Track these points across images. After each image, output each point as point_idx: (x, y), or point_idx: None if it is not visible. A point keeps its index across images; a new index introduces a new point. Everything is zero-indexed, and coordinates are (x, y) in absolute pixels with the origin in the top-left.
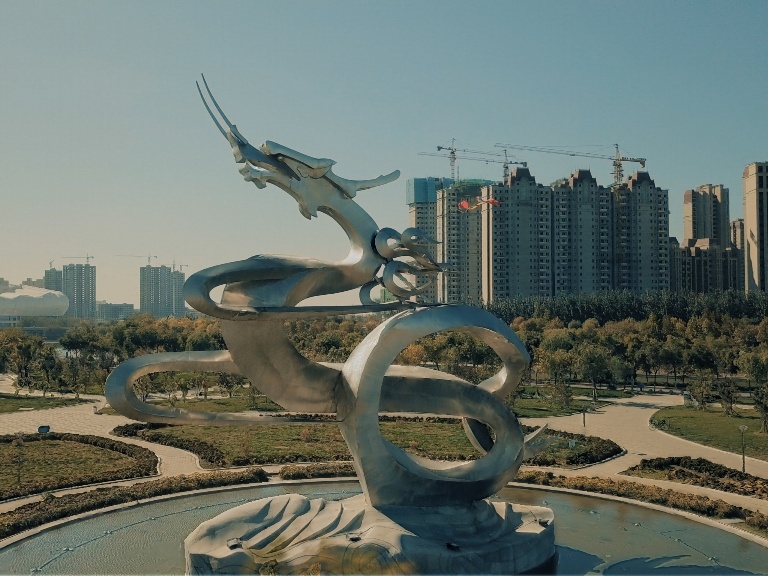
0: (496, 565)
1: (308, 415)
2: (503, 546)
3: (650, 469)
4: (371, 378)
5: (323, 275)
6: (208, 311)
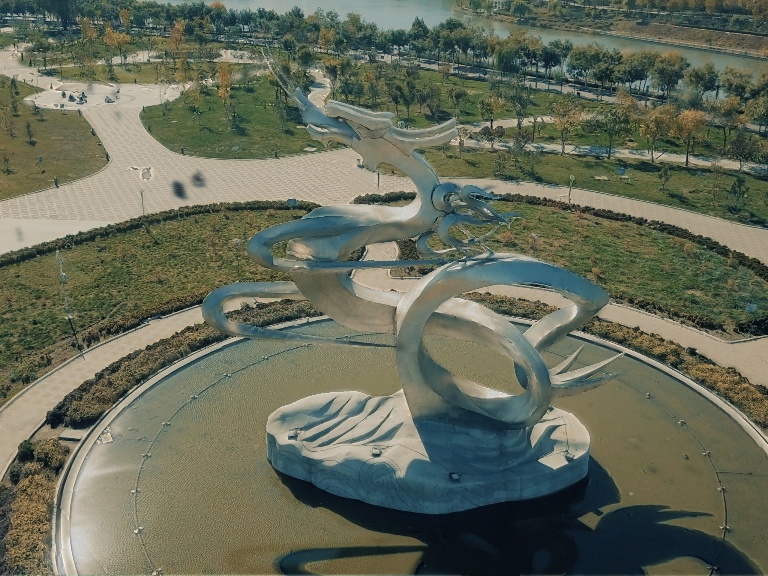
0: (500, 492)
1: (537, 197)
2: (510, 478)
3: None
4: (412, 324)
5: (377, 229)
6: (267, 266)
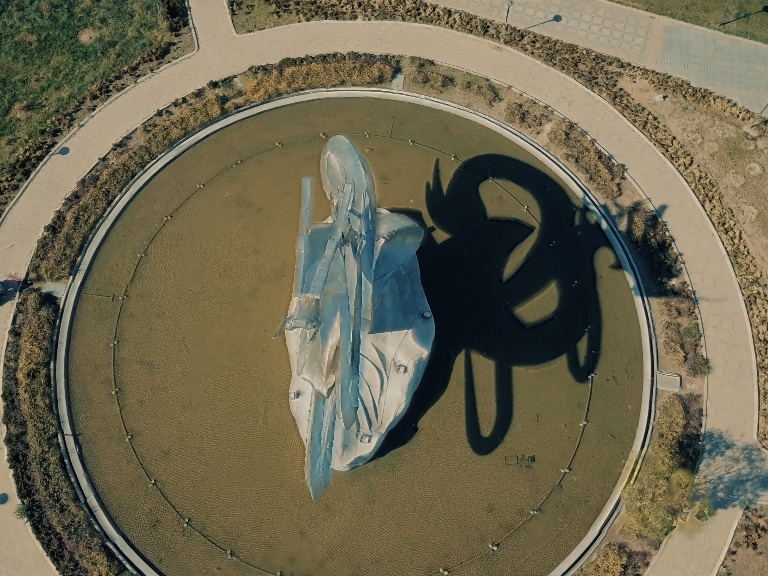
0: None
1: None
2: None
3: (248, 6)
4: None
5: None
6: None
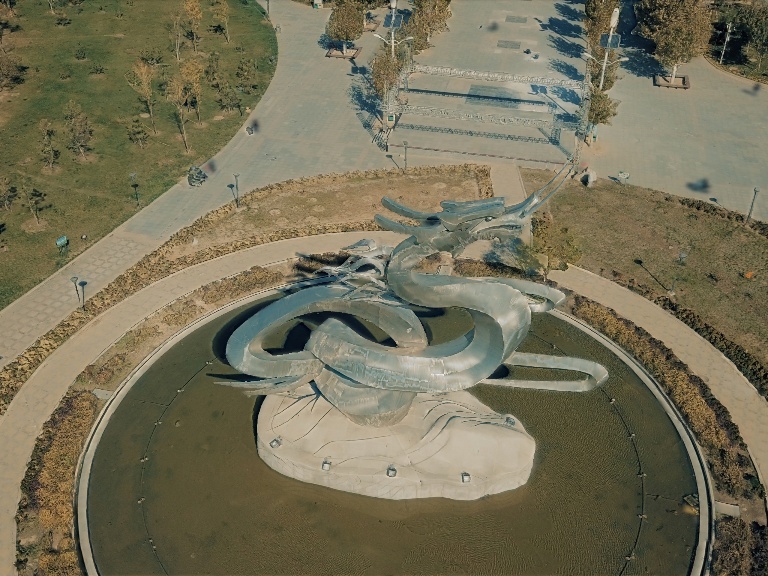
0: None
1: None
2: None
3: None
4: None
5: None
6: None
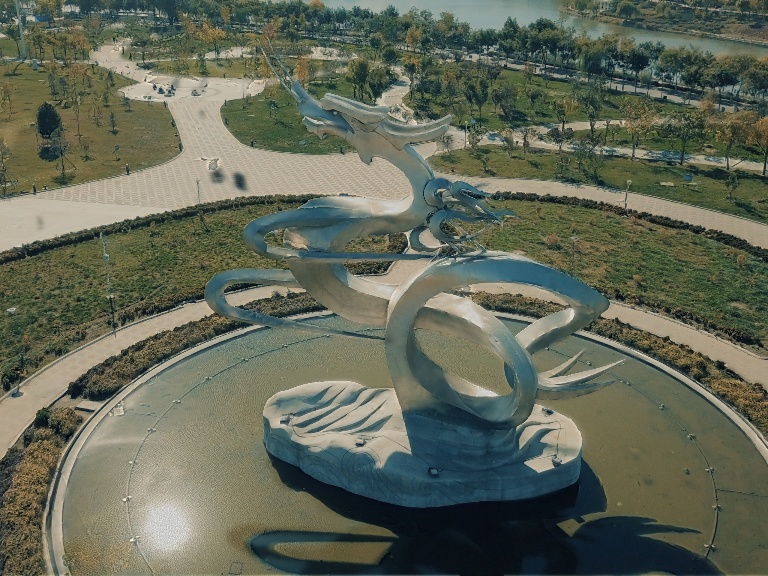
0: (481, 491)
1: (594, 201)
2: (492, 478)
3: None
4: (400, 318)
5: (369, 222)
6: (260, 253)
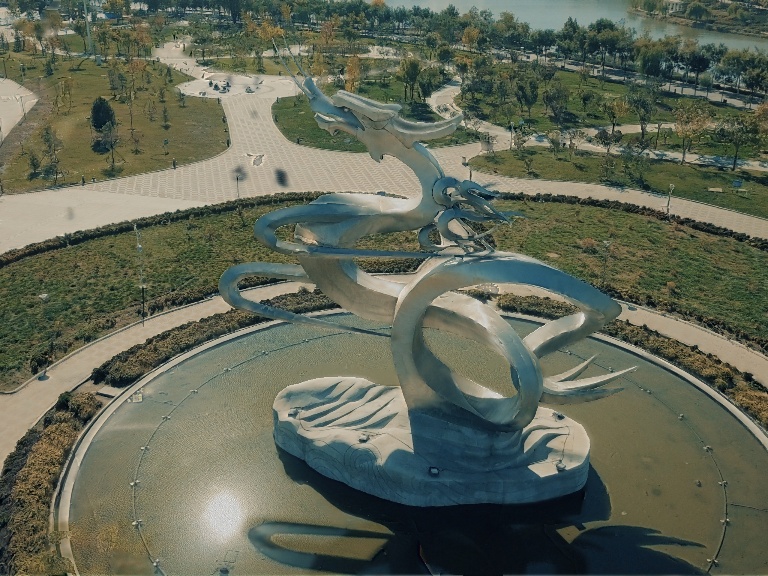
0: (481, 493)
1: (636, 206)
2: (493, 480)
3: None
4: (406, 316)
5: (378, 219)
6: (270, 247)
